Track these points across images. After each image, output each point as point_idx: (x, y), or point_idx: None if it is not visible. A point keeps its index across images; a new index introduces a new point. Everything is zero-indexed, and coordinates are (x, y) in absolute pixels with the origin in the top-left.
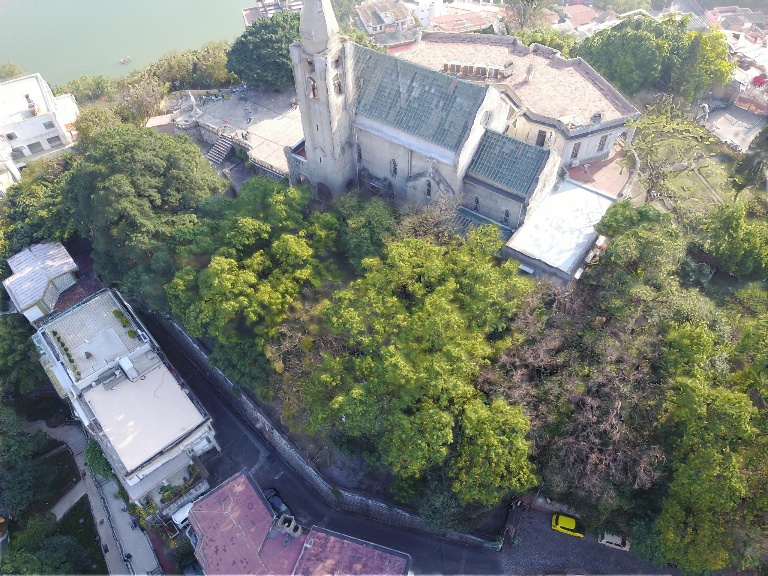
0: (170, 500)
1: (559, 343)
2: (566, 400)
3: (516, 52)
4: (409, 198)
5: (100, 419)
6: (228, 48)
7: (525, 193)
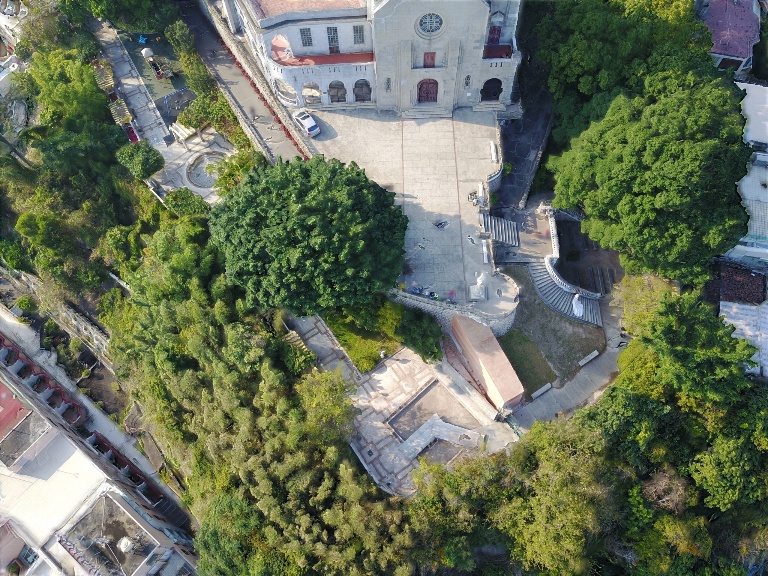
0: None
1: None
2: None
3: None
4: None
5: None
6: (272, 442)
7: None
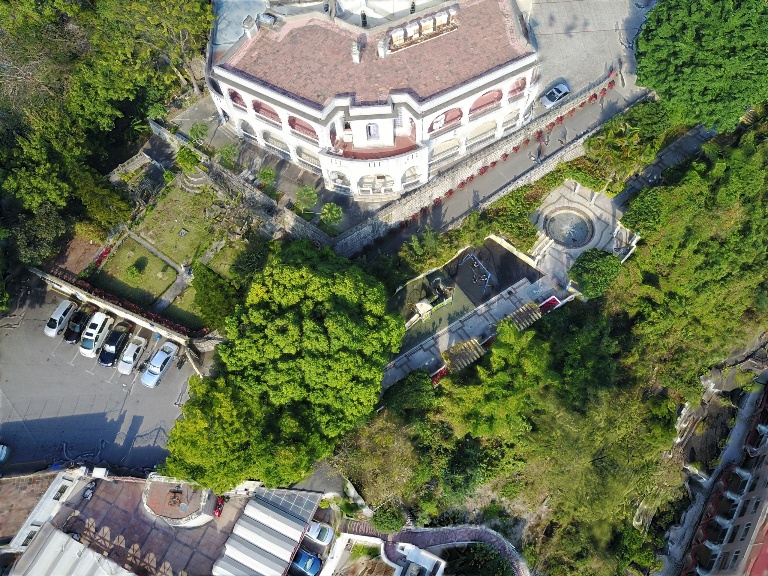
0: None
1: None
2: None
3: None
4: None
5: None
6: None
7: None
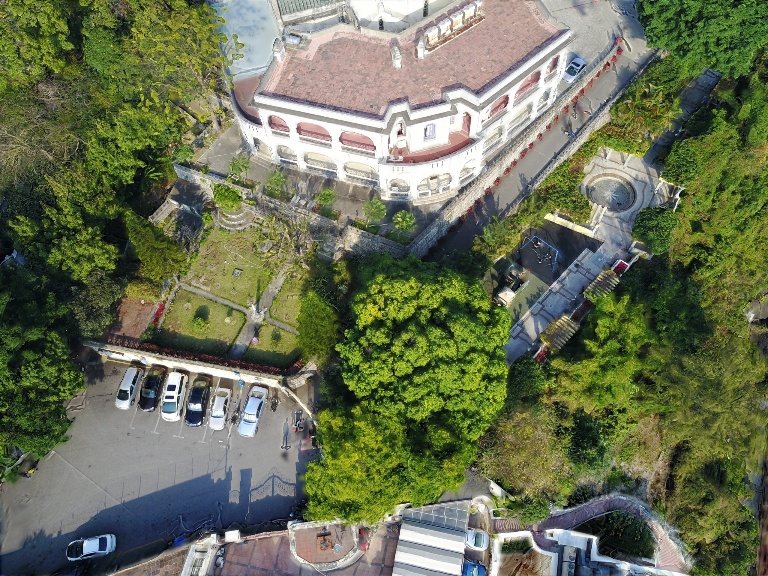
0: None
1: None
2: None
3: None
4: None
5: None
6: None
7: None
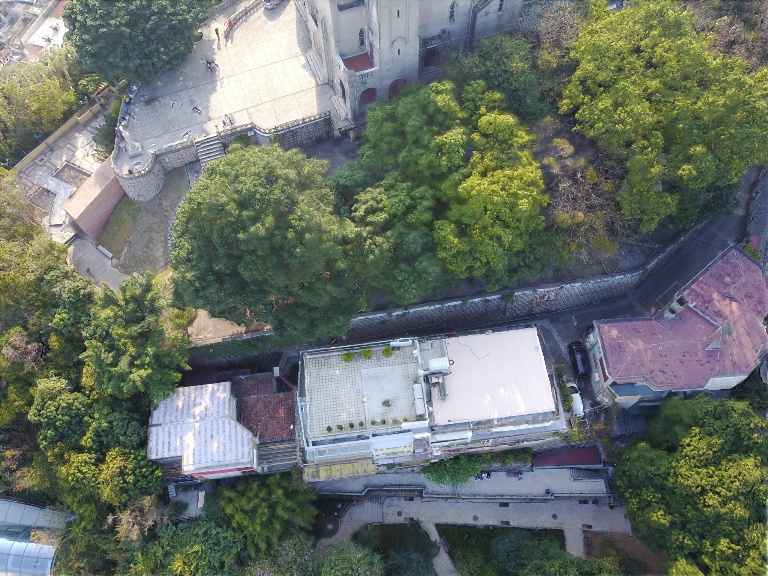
0: None
1: None
2: (762, 44)
3: None
4: (478, 30)
5: (478, 417)
6: None
7: None
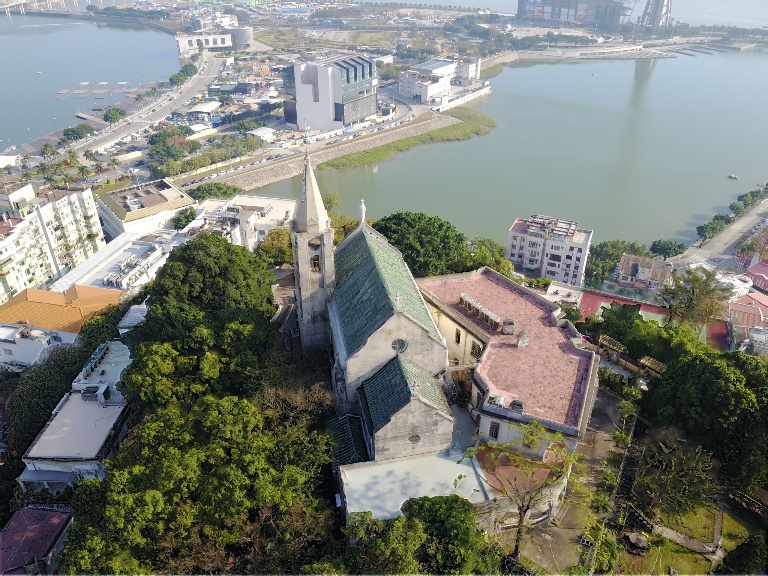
0: (39, 500)
1: (261, 573)
2: None
3: (546, 320)
4: (332, 385)
5: (58, 414)
6: None
7: (374, 427)
